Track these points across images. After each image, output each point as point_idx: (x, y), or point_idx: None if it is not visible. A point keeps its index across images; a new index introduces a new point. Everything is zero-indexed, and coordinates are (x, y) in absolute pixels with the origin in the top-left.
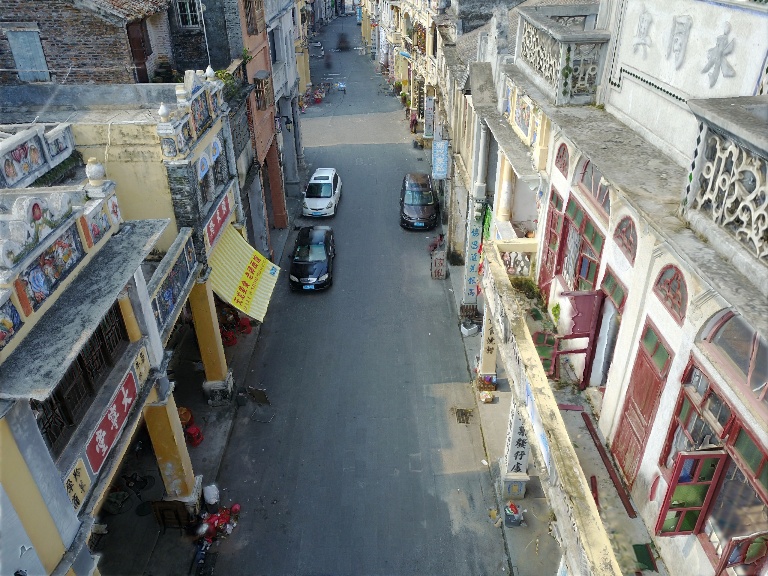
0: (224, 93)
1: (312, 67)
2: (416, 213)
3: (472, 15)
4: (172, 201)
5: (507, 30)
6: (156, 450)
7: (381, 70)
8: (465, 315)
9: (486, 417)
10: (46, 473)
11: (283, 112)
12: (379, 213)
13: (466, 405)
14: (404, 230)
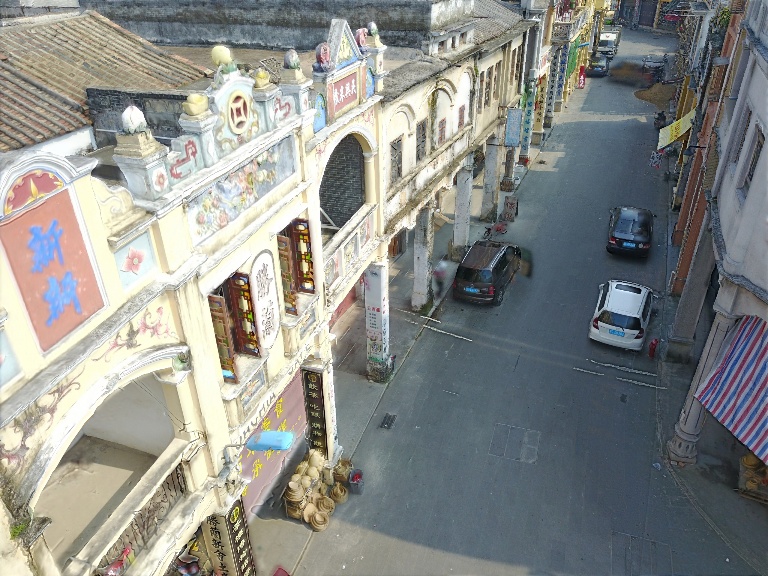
0: None
1: None
2: None
3: None
4: None
5: None
6: None
7: None
8: None
9: (532, 157)
10: None
11: None
12: (538, 292)
13: (538, 164)
14: None
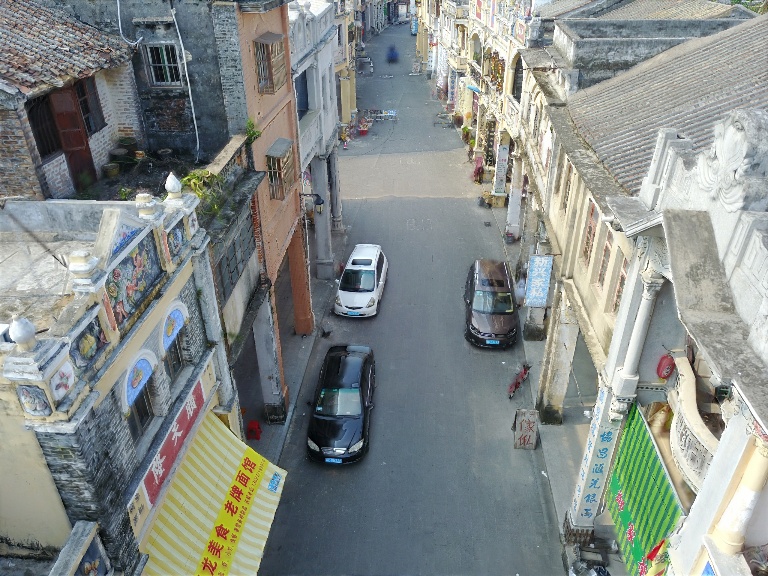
0: (205, 205)
1: (359, 86)
2: (489, 325)
3: (594, 63)
4: (54, 481)
5: (767, 161)
6: None
7: (438, 93)
8: (573, 540)
9: None
10: None
11: (315, 175)
12: (436, 313)
13: None
14: (471, 347)
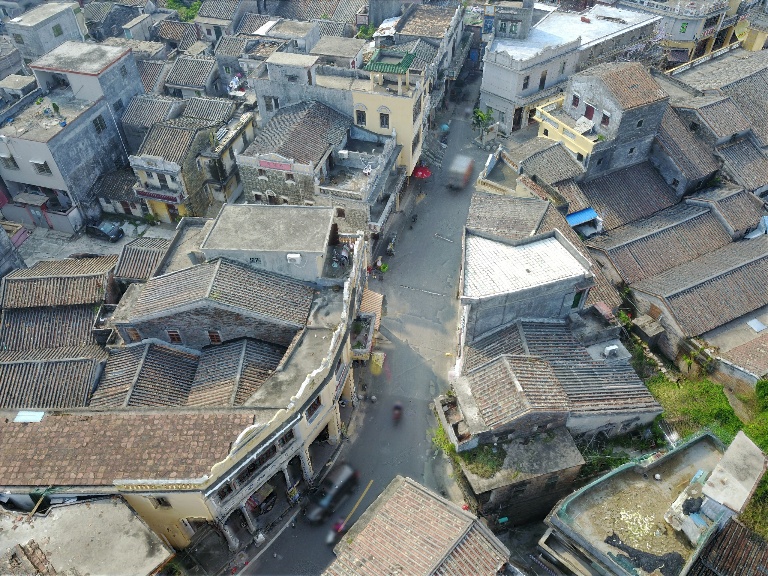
0: None
1: None
2: None
3: None
4: (738, 8)
5: None
6: (707, 48)
7: None
8: None
9: None
10: (702, 28)
11: None
12: None
13: None
14: None
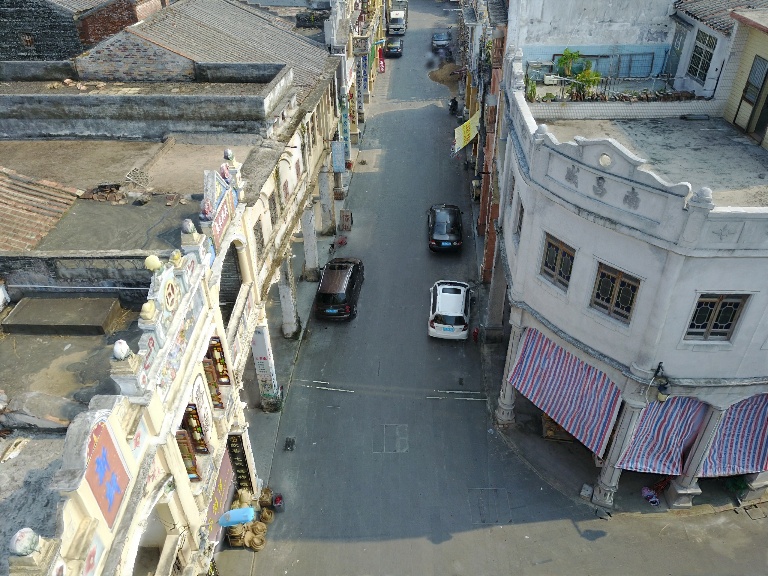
0: None
1: None
2: None
3: None
4: None
5: None
6: None
7: None
8: None
9: None
10: None
11: None
12: (384, 299)
13: (360, 165)
14: None
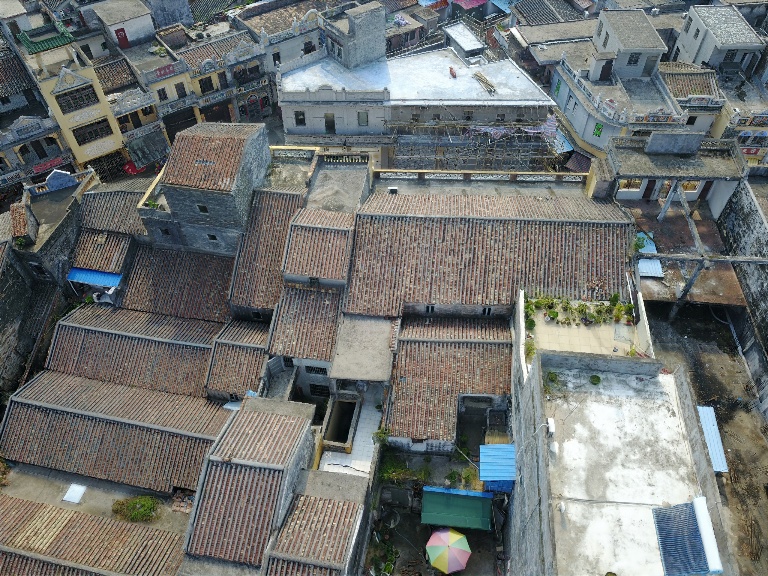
0: None
1: None
2: None
3: None
4: None
5: None
6: None
7: None
8: None
9: None
10: None
11: None
12: None
13: None
14: None
